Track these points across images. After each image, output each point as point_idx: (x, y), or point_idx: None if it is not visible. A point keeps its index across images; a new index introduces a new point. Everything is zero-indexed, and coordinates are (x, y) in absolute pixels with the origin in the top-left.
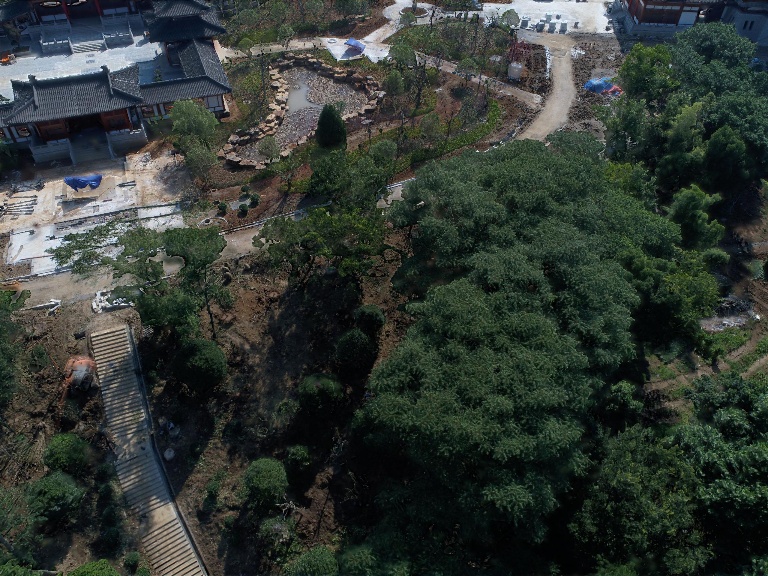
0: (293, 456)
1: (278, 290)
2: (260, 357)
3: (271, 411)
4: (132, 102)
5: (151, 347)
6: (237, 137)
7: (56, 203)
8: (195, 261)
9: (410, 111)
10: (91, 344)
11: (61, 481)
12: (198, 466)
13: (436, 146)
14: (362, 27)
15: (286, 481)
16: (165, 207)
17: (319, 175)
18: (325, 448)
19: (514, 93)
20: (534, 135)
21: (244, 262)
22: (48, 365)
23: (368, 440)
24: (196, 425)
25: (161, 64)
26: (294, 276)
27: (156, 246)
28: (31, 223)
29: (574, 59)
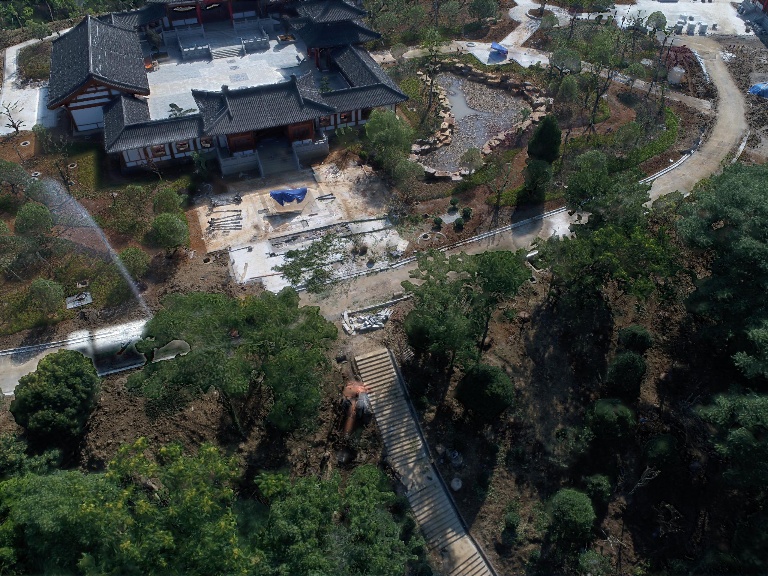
0: (600, 487)
1: (527, 309)
2: (524, 380)
3: (549, 437)
4: (325, 112)
5: (414, 371)
6: (419, 147)
7: (261, 218)
8: (516, 286)
9: (588, 118)
10: (357, 368)
11: (387, 518)
12: (488, 497)
13: (630, 155)
14: (496, 30)
15: (594, 513)
16: (375, 221)
17: (586, 191)
18: (612, 476)
19: (681, 99)
20: (721, 143)
21: (481, 280)
22: (335, 393)
23: (731, 476)
24: (477, 453)
25: (309, 70)
26: (575, 298)
27: (474, 271)
28: (245, 239)
29: (728, 62)
